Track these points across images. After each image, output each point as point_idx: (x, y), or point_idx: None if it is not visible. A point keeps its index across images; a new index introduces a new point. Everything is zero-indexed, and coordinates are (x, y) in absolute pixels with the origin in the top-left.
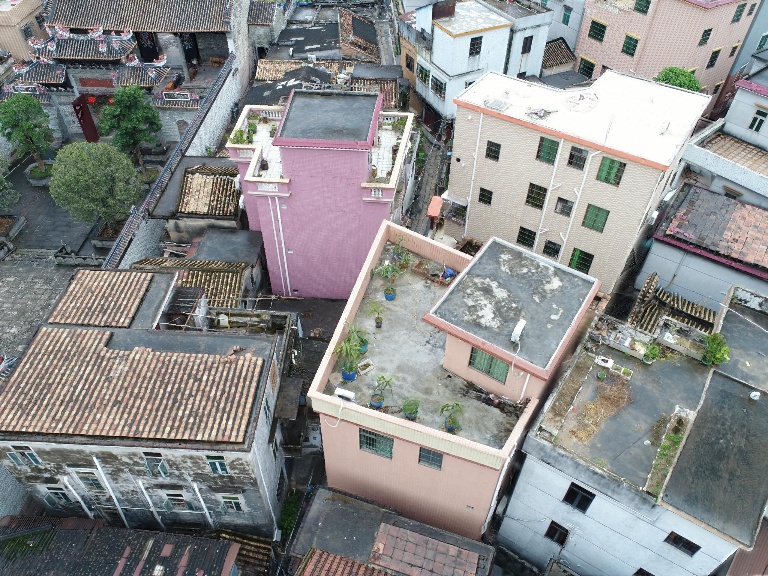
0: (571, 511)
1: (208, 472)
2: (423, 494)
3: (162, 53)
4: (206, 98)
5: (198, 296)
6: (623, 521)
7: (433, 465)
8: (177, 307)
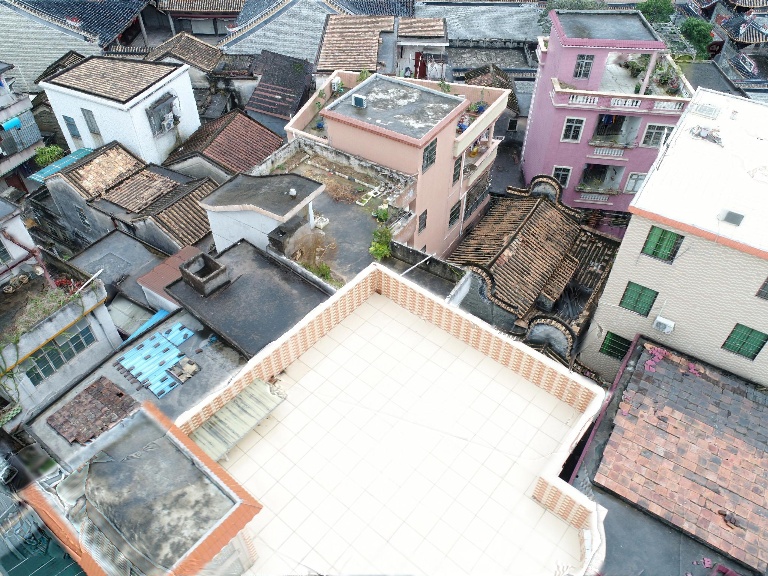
0: None
1: None
2: None
3: None
4: (766, 81)
5: (437, 59)
6: None
7: None
8: (426, 55)
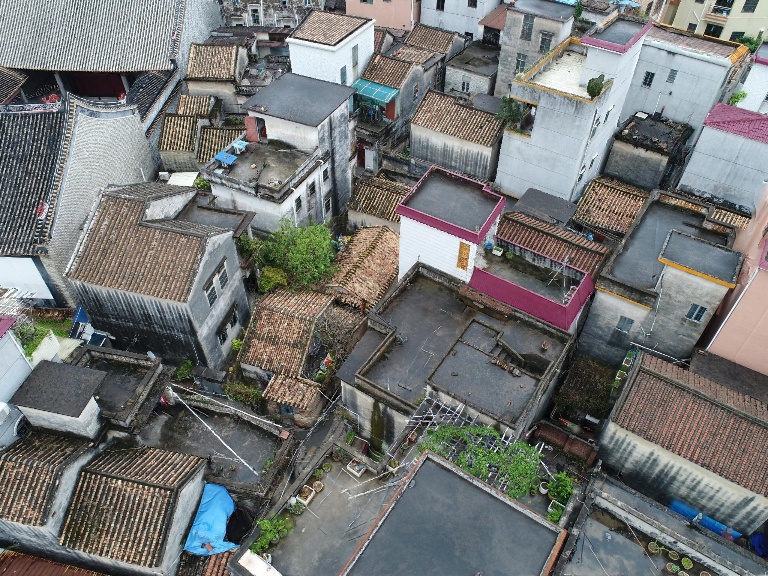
0: (440, 13)
1: (303, 5)
2: (386, 26)
3: None
4: None
5: None
6: (455, 4)
7: (388, 1)
8: None
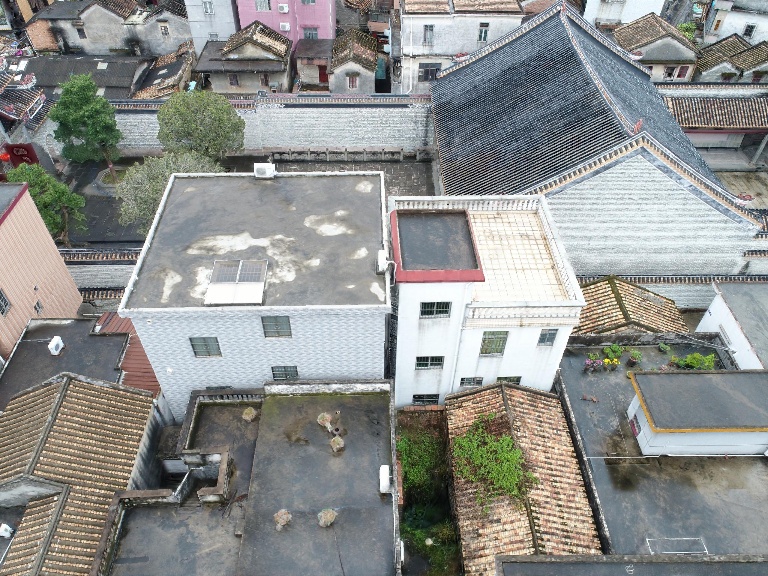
0: None
1: None
2: None
3: None
4: None
5: None
6: None
7: None
8: None
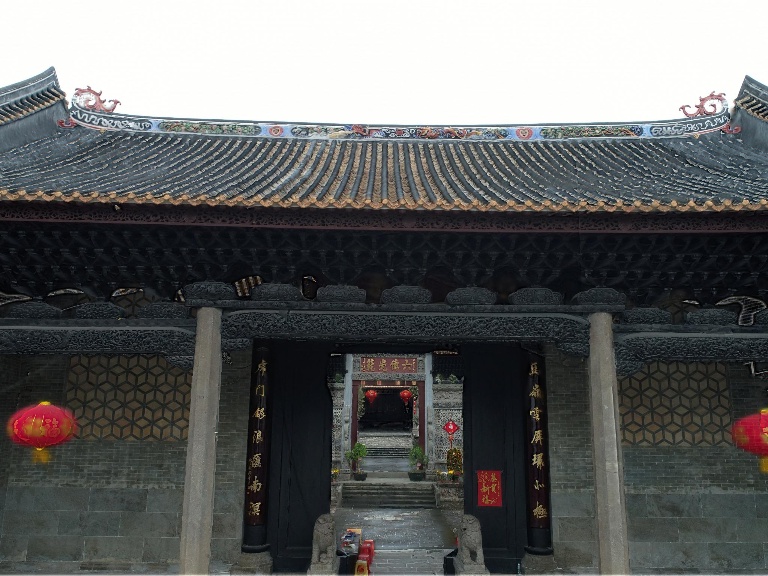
0: None
1: None
2: None
3: (464, 552)
4: None
5: None
6: None
7: None
8: None
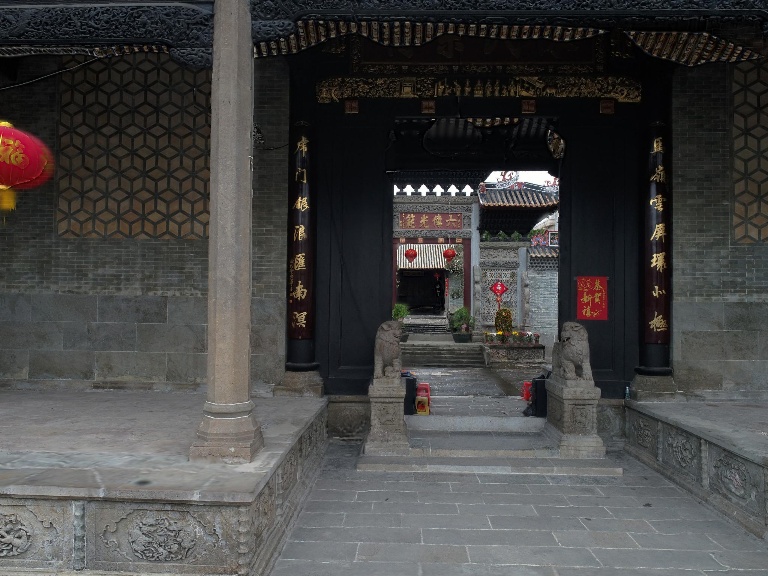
0: None
1: None
2: None
3: (565, 367)
4: None
5: None
6: None
7: None
8: None
